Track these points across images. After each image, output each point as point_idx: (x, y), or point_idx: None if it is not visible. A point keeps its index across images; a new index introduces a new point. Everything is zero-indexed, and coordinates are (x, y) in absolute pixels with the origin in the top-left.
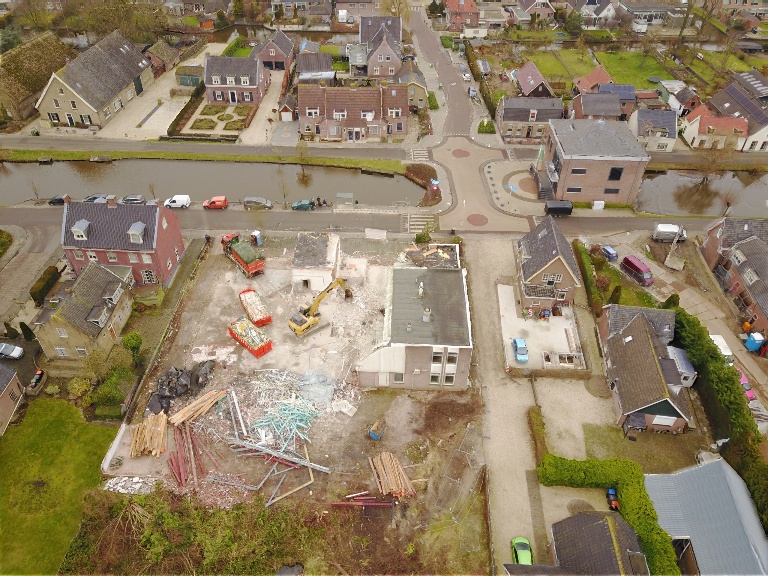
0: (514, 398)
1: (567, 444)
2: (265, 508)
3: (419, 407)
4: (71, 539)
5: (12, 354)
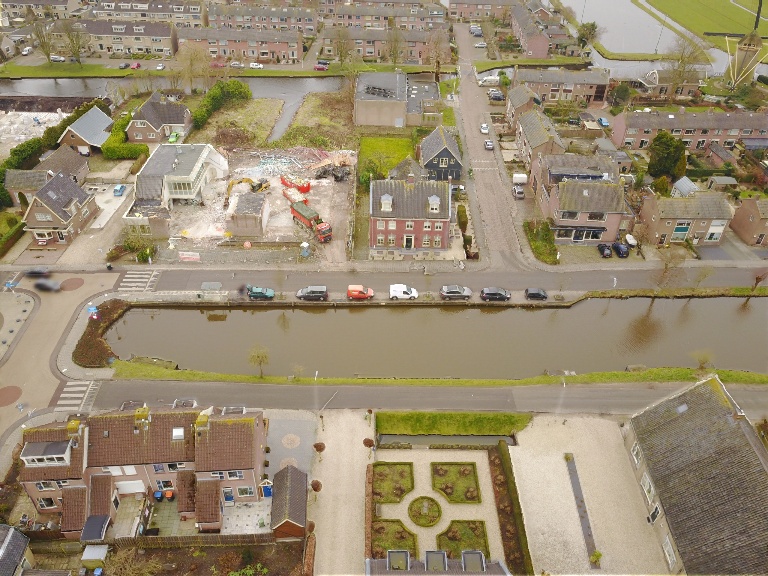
0: None
1: (125, 166)
2: None
3: None
4: None
5: None
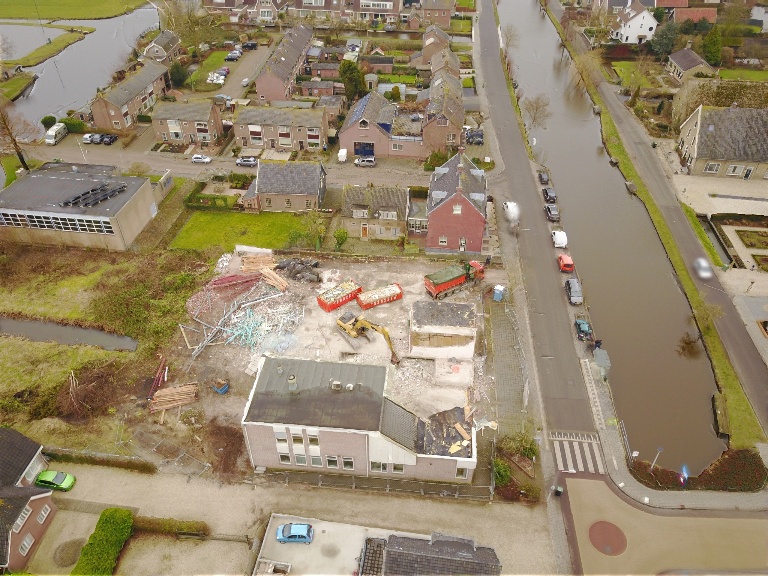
0: (231, 517)
1: (154, 562)
2: None
3: None
4: None
5: None
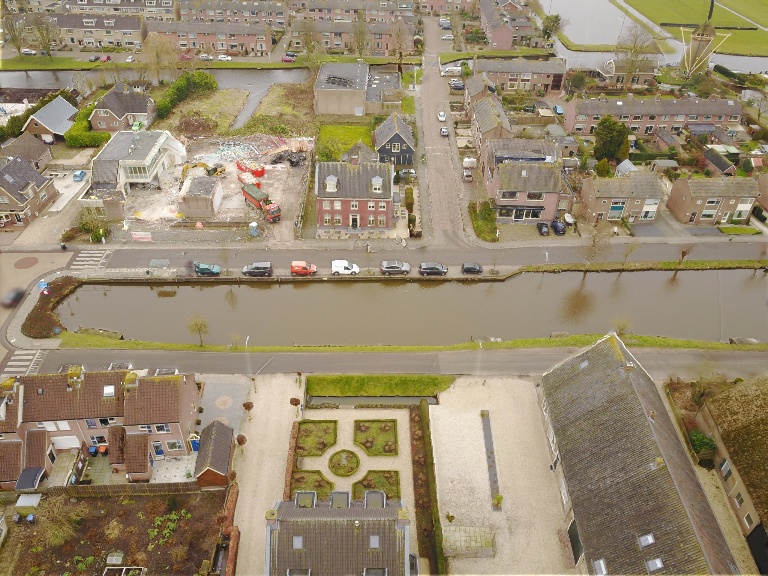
0: None
1: None
2: None
3: None
4: None
5: None
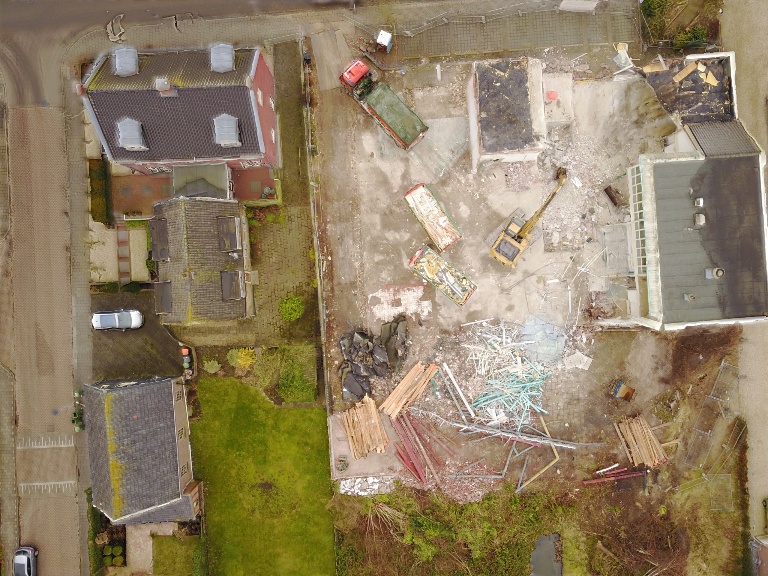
0: None
1: None
2: (514, 493)
3: (665, 346)
4: (334, 547)
5: (133, 325)
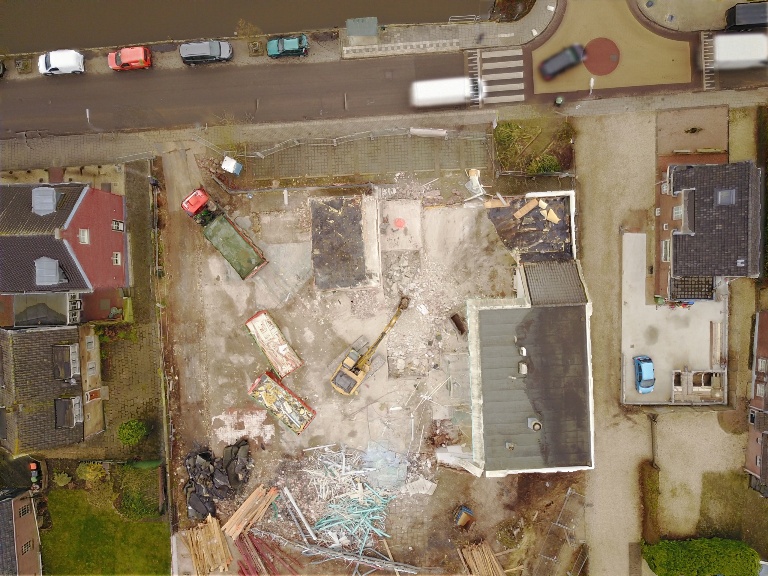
0: (626, 446)
1: (680, 504)
2: None
3: None
4: None
5: None
